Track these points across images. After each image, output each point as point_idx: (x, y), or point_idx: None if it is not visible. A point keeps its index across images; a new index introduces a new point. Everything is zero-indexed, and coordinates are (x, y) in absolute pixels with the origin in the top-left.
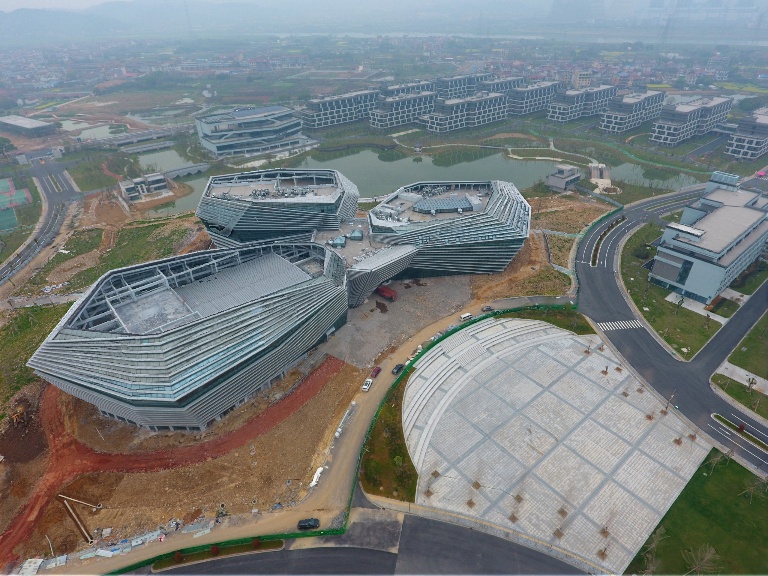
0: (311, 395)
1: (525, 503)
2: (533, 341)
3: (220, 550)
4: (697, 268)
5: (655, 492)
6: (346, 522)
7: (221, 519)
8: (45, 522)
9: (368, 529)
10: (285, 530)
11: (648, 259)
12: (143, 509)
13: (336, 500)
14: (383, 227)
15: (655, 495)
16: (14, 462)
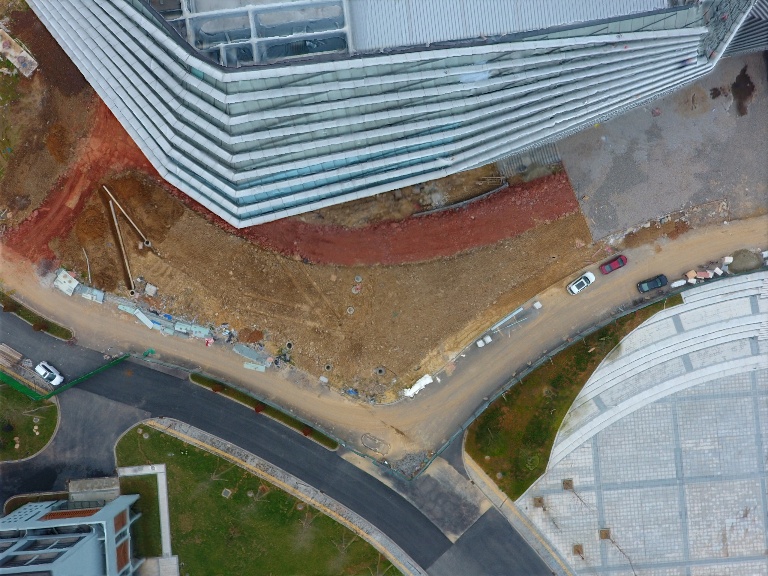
0: (485, 239)
1: None
2: None
3: (266, 407)
4: None
5: None
6: (420, 470)
7: (281, 364)
8: (81, 231)
9: (439, 495)
10: (347, 430)
11: None
12: (196, 286)
13: (424, 433)
14: None
15: None
16: (51, 84)
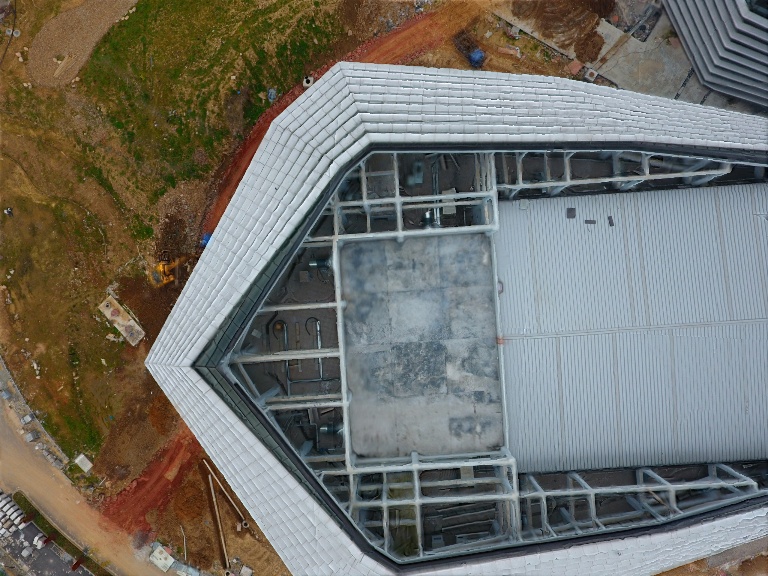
0: None
1: None
2: None
3: None
4: None
5: None
6: None
7: None
8: (181, 512)
9: None
10: None
11: None
12: None
13: None
14: None
15: None
16: None
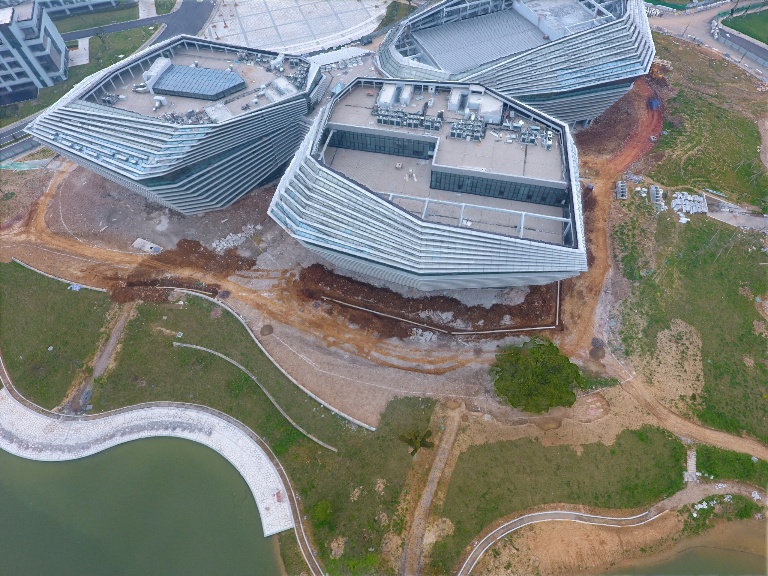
0: None
1: None
2: None
3: None
4: (48, 27)
5: None
6: (431, 1)
7: None
8: None
9: None
10: None
11: (13, 104)
12: None
13: None
14: None
15: None
16: None
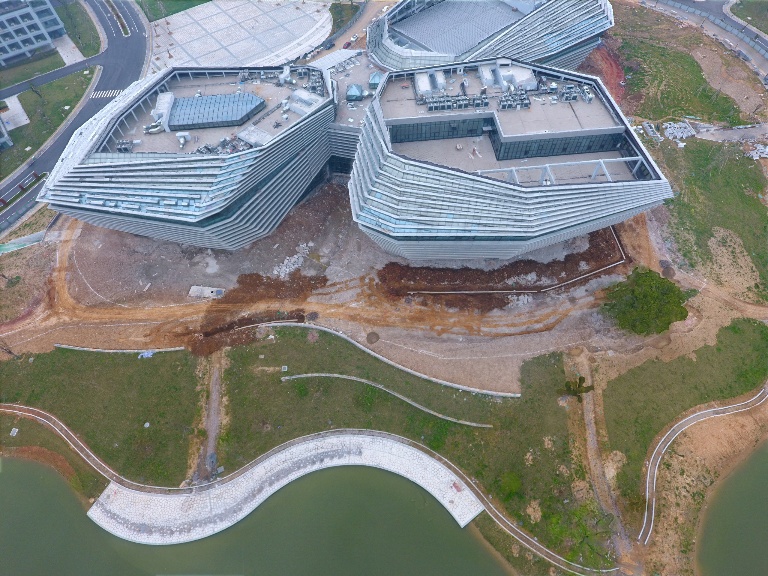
0: None
1: (276, 3)
2: None
3: None
4: None
5: (206, 7)
6: None
7: None
8: None
9: None
10: None
11: None
12: None
13: (374, 3)
14: None
15: (207, 6)
16: None
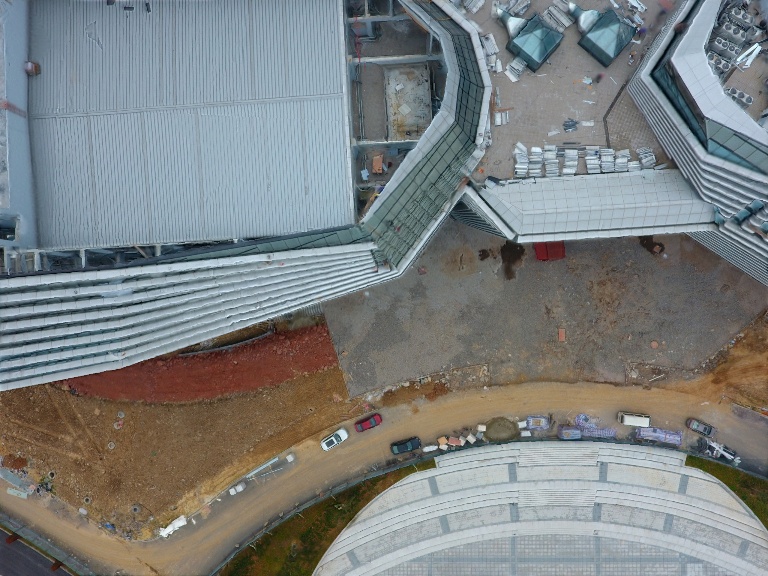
0: (245, 386)
1: None
2: (696, 549)
3: None
4: None
5: None
6: None
7: (42, 492)
8: None
9: None
10: (102, 564)
11: None
12: None
13: (177, 574)
14: (689, 95)
15: None
16: None
